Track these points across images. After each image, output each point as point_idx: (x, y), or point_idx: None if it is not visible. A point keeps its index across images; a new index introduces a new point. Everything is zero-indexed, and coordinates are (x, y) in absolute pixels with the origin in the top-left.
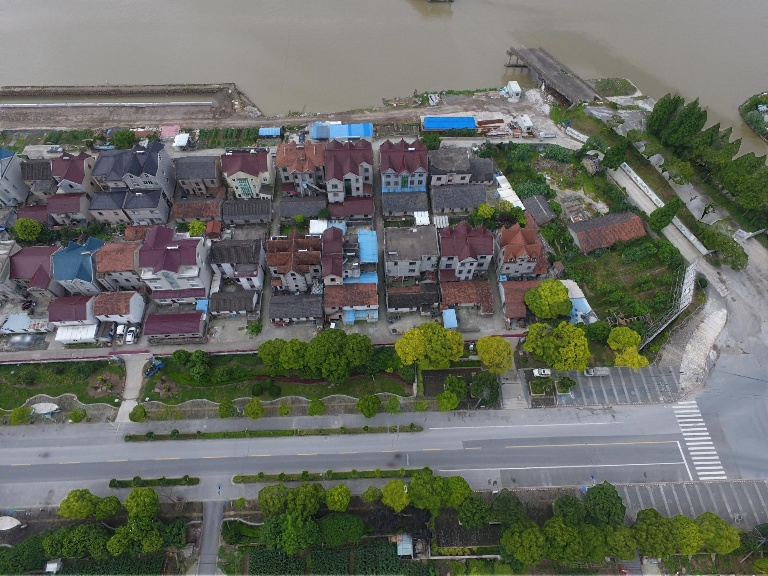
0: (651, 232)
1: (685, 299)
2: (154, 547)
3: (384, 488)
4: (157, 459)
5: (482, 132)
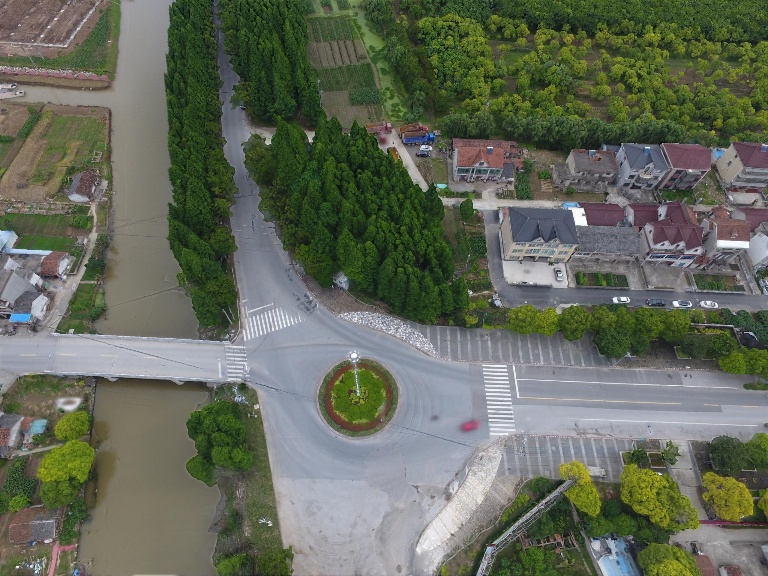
0: None
1: None
2: None
3: None
4: None
5: None
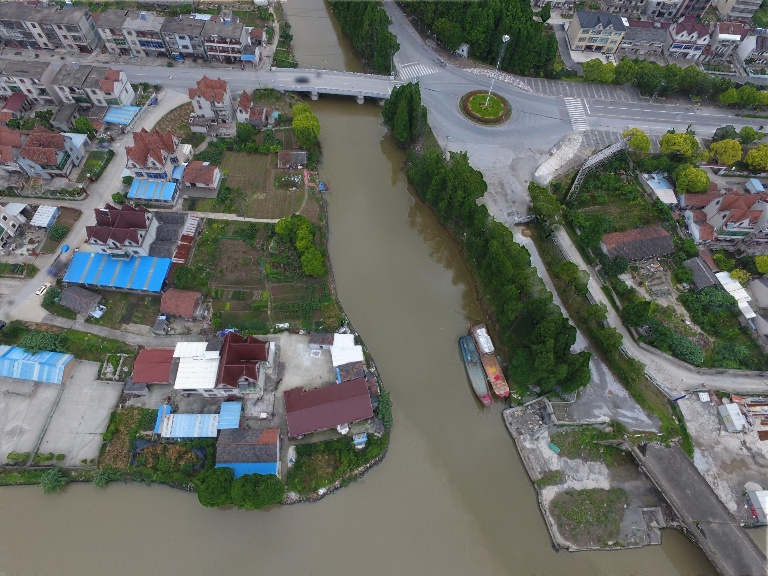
0: None
1: None
2: None
3: None
4: None
5: None
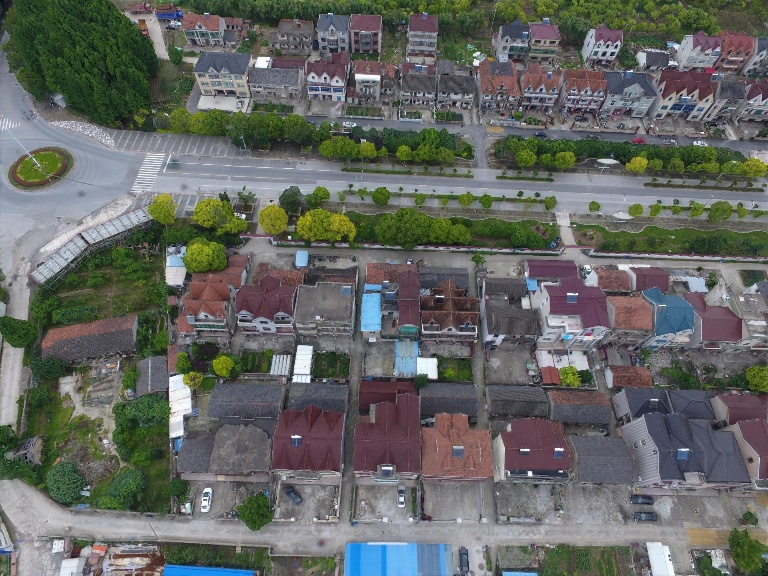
0: (39, 337)
1: (76, 247)
2: (511, 140)
3: (375, 152)
4: (529, 191)
5: (156, 564)
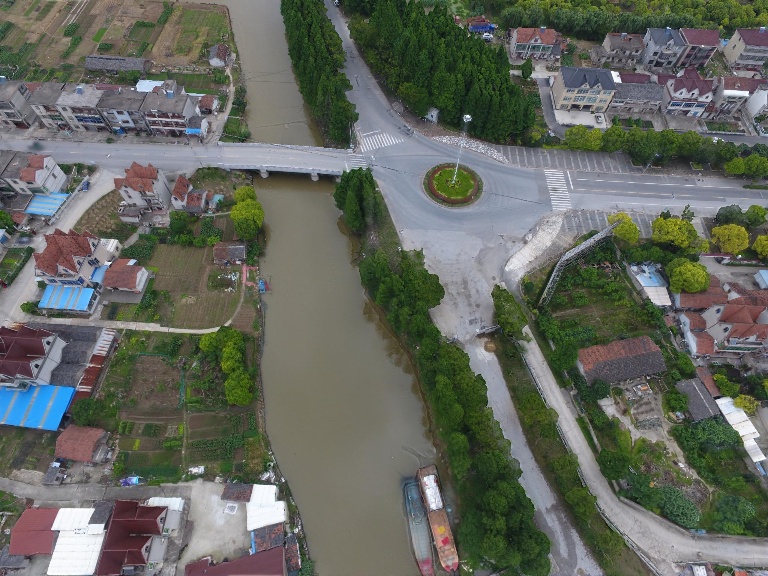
0: None
1: None
2: None
3: None
4: None
5: None
